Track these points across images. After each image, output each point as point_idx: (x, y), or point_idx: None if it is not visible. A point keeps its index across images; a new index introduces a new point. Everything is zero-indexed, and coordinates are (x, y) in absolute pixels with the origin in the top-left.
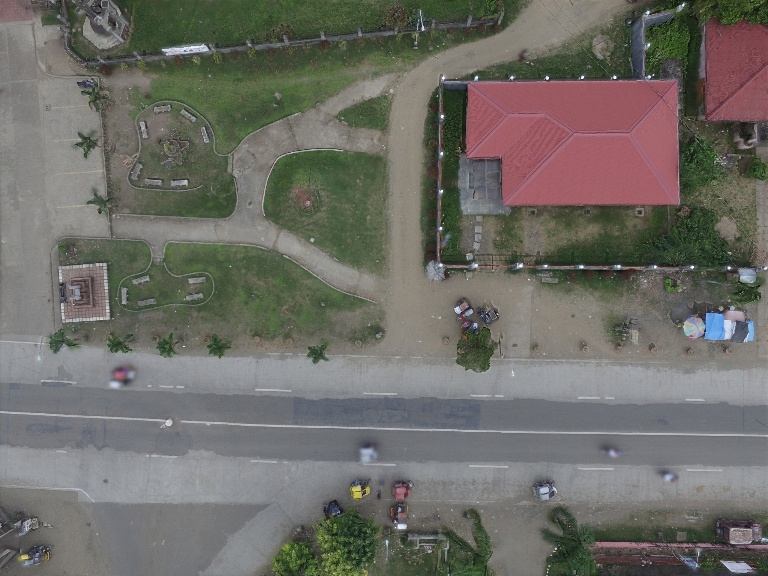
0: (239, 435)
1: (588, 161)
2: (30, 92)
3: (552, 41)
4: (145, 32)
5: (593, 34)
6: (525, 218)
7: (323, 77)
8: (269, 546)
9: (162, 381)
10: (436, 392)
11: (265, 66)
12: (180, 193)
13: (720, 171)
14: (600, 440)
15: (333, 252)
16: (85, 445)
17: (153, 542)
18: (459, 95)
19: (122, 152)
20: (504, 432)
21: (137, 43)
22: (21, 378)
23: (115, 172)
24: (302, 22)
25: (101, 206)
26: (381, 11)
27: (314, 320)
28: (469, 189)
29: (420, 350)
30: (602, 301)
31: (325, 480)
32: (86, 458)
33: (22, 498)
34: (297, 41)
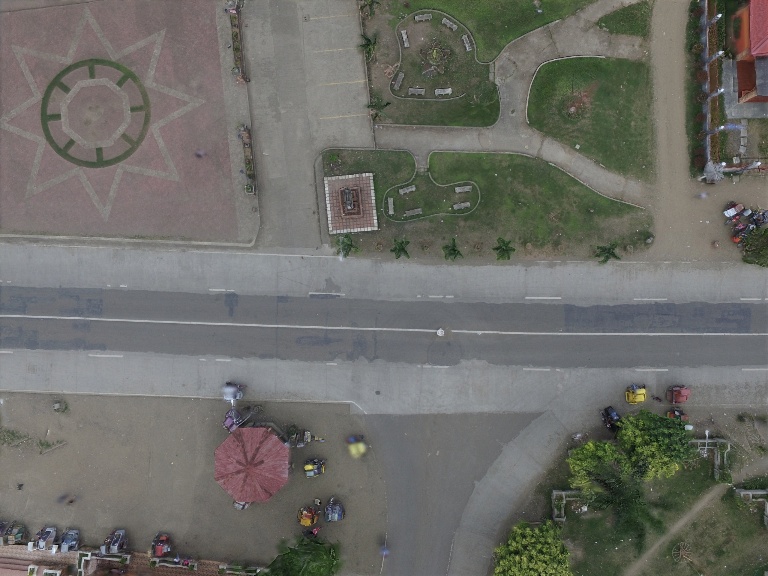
0: (511, 343)
1: None
2: (288, 3)
3: None
4: None
5: None
6: None
7: None
8: (544, 454)
9: (431, 291)
10: (706, 296)
11: None
12: (443, 102)
13: None
14: None
15: (599, 158)
16: (356, 357)
17: (427, 453)
18: None
19: (383, 62)
20: None
21: None
22: (288, 291)
23: (376, 82)
24: None
25: (381, 110)
26: None
27: (582, 227)
28: (733, 93)
29: (688, 255)
30: None
31: (598, 387)
32: (357, 370)
33: (292, 412)
34: None
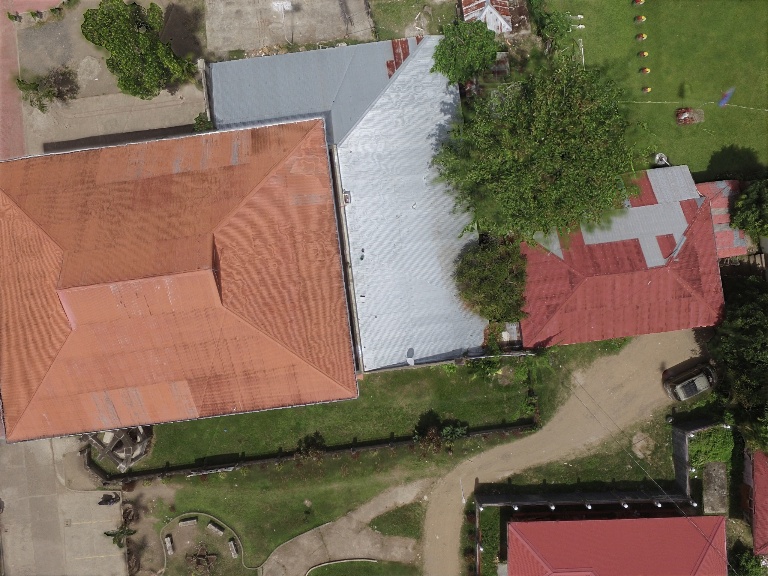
0: None
1: None
2: (49, 507)
3: (590, 440)
4: (168, 443)
5: (633, 432)
6: None
7: (354, 483)
8: None
9: None
10: None
11: (294, 473)
12: None
13: (766, 572)
14: None
15: None
16: None
17: None
18: None
19: (147, 568)
20: None
21: (160, 454)
22: None
23: None
24: (331, 428)
25: None
26: (413, 415)
27: None
28: None
29: None
30: None
31: None
32: None
33: None
34: None
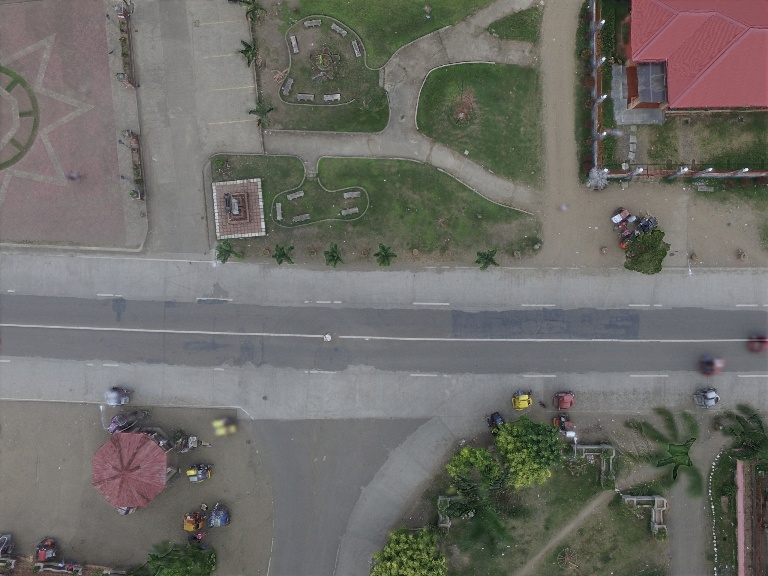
0: (398, 349)
1: (760, 58)
2: (178, 8)
3: None
4: None
5: None
6: (679, 127)
7: None
8: (431, 460)
9: (319, 297)
10: (594, 303)
11: None
12: (332, 108)
13: None
14: (759, 347)
15: (488, 164)
16: (243, 362)
17: (314, 458)
18: (611, 5)
19: (273, 67)
20: (664, 341)
21: None
22: (176, 296)
23: (266, 88)
24: None
25: (263, 116)
26: None
27: (470, 233)
28: (623, 99)
29: (577, 261)
30: (757, 209)
31: (485, 393)
32: (244, 375)
33: (180, 417)
34: None
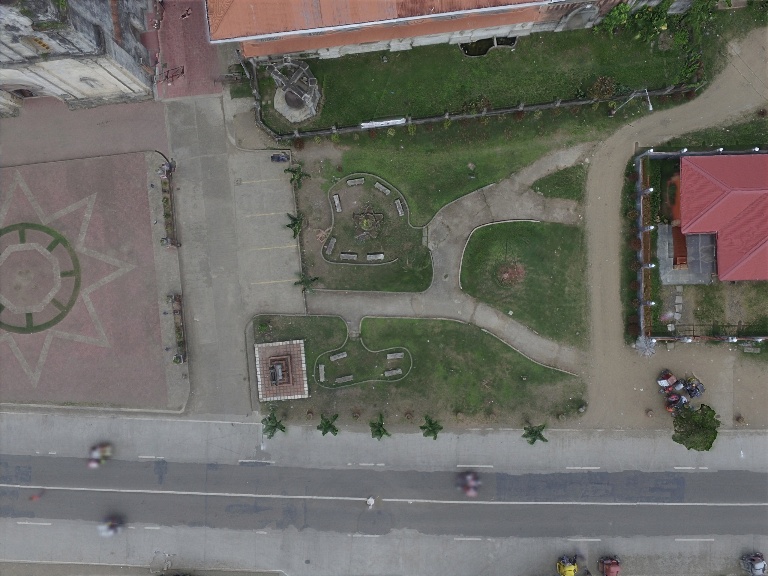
0: (442, 513)
1: None
2: (220, 166)
3: (747, 107)
4: (337, 104)
5: None
6: (726, 287)
7: (517, 147)
8: None
9: (362, 459)
10: (639, 465)
11: (458, 136)
12: (375, 267)
13: None
14: None
15: (532, 325)
16: (285, 526)
17: None
18: (657, 164)
19: (315, 226)
20: (710, 505)
21: (328, 115)
22: (218, 458)
23: (308, 247)
24: (495, 91)
25: (308, 286)
26: (575, 79)
27: (514, 394)
28: (668, 259)
29: (622, 423)
30: None
31: (530, 557)
32: (287, 539)
33: None
34: (494, 112)
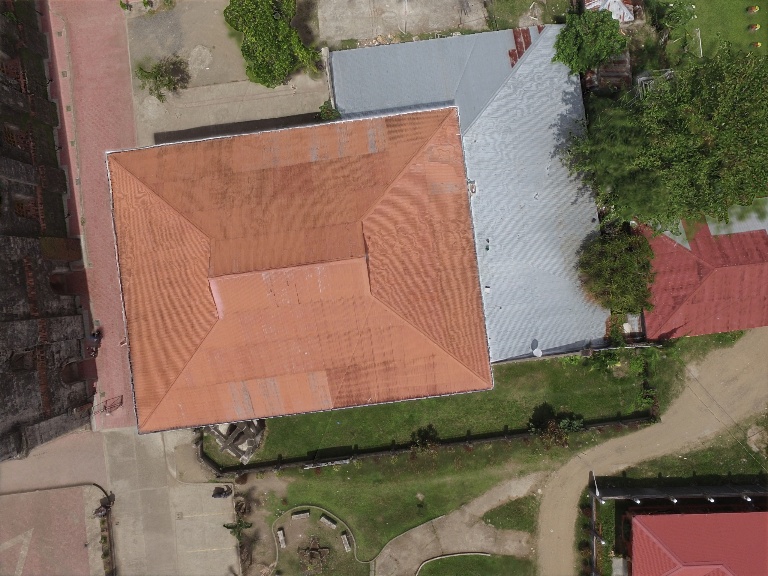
0: None
1: None
2: (160, 500)
3: (705, 433)
4: (280, 436)
5: (747, 425)
6: None
7: (467, 476)
8: None
9: None
10: None
11: (406, 466)
12: None
13: None
14: None
15: None
16: None
17: None
18: None
19: (259, 561)
20: None
21: (272, 447)
22: None
23: None
24: (445, 421)
25: None
26: (527, 407)
27: None
28: None
29: None
30: None
31: None
32: None
33: None
34: None
